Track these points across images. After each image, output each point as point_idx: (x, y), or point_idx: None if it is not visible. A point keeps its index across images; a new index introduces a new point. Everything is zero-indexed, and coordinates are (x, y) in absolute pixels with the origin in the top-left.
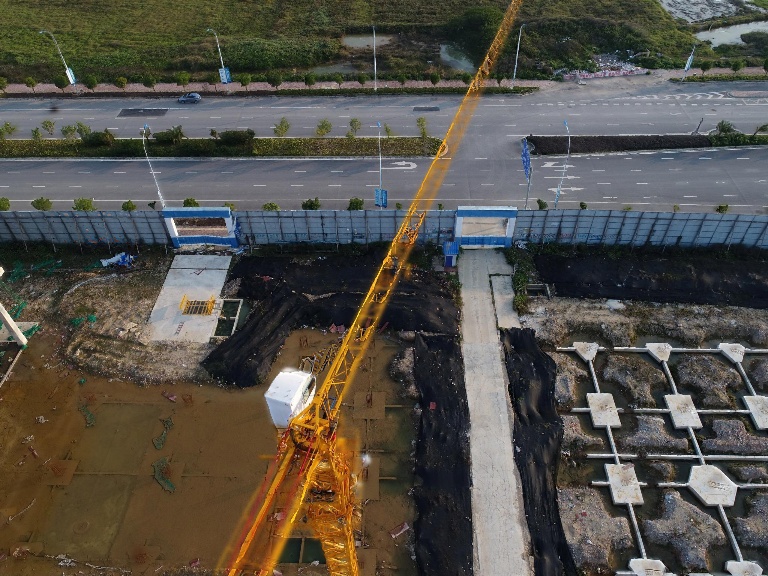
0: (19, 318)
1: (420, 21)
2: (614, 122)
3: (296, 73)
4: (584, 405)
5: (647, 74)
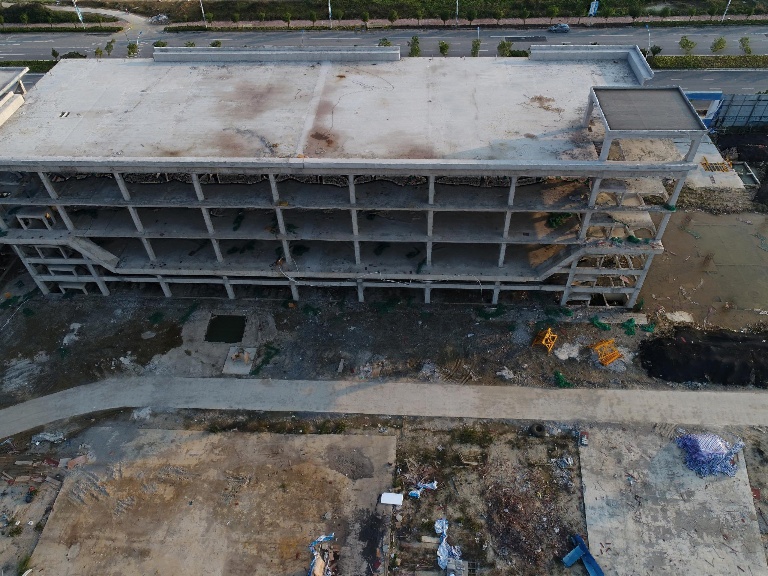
0: None
1: None
2: None
3: None
4: None
5: None
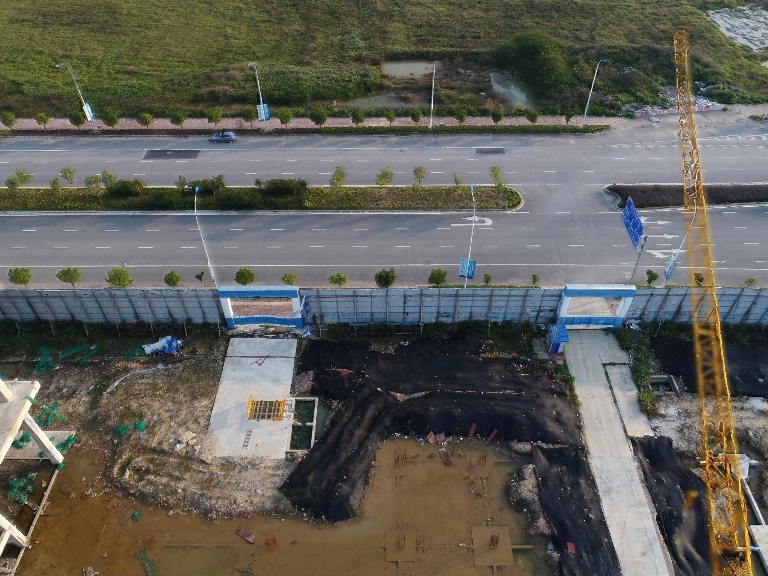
0: (51, 425)
1: (465, 46)
2: (702, 168)
3: (338, 107)
4: None
5: (725, 110)
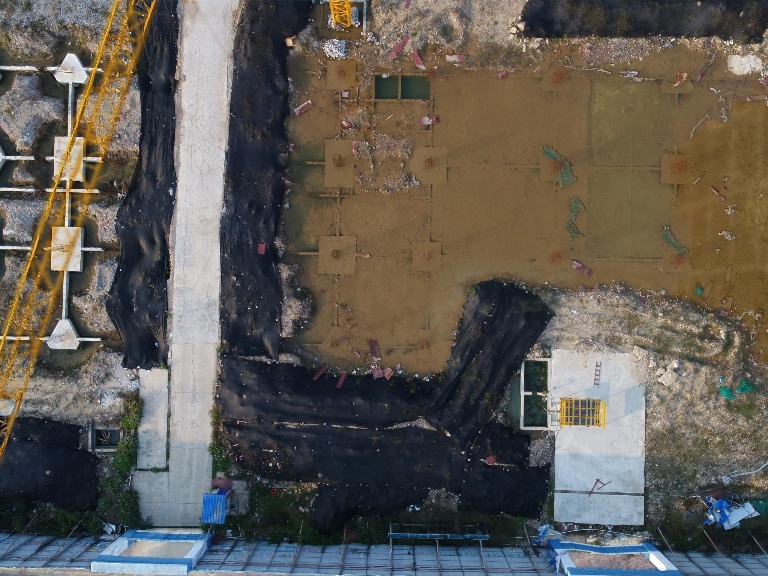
0: None
1: None
2: None
3: None
4: (88, 260)
5: None
